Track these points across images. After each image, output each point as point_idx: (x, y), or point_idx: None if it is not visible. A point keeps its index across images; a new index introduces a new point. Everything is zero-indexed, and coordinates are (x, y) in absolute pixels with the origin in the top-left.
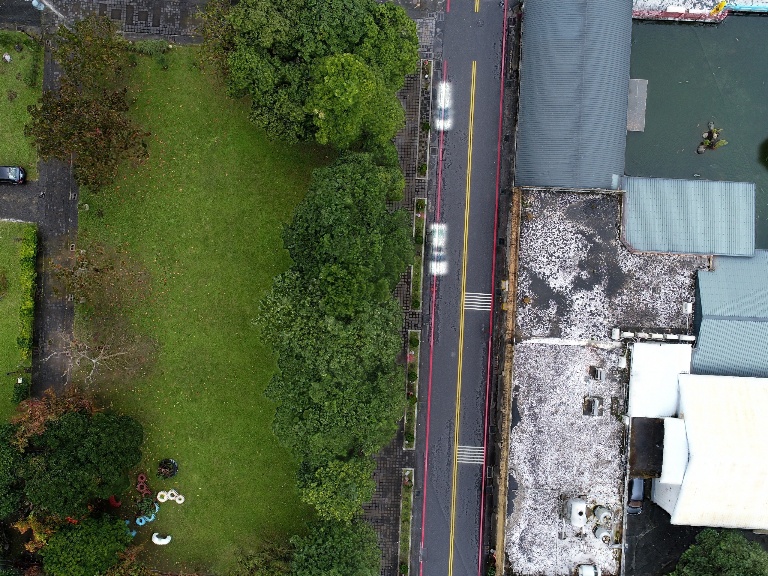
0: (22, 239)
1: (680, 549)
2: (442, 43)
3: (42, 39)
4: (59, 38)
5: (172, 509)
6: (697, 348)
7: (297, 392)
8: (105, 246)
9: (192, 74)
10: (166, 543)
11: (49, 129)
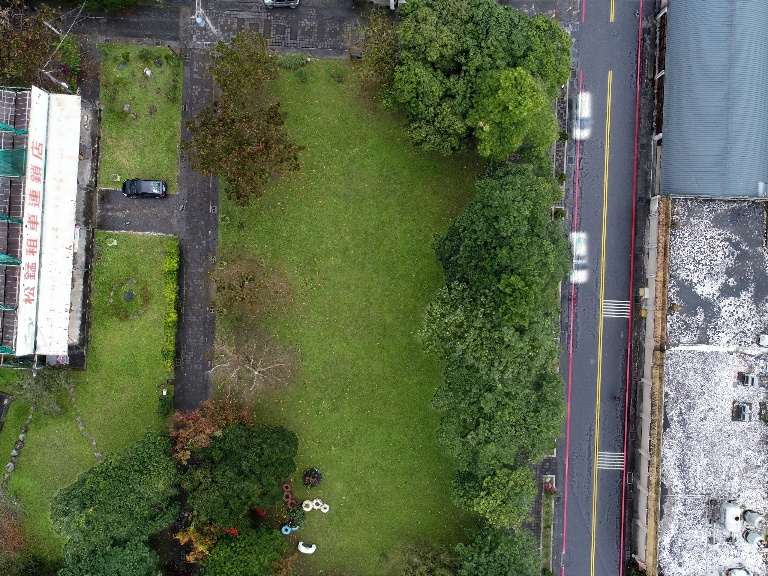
0: (167, 252)
1: None
2: (578, 53)
3: (181, 54)
4: (214, 54)
5: (316, 518)
6: None
7: (467, 402)
8: (246, 258)
9: (330, 87)
10: (312, 552)
11: (210, 144)
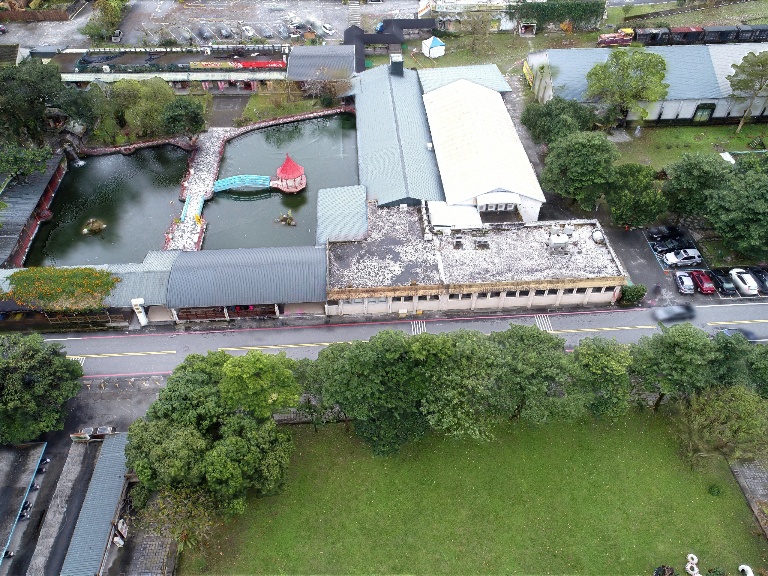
0: None
1: (562, 213)
2: None
3: None
4: None
5: None
6: None
7: None
8: None
9: None
10: (747, 567)
11: None
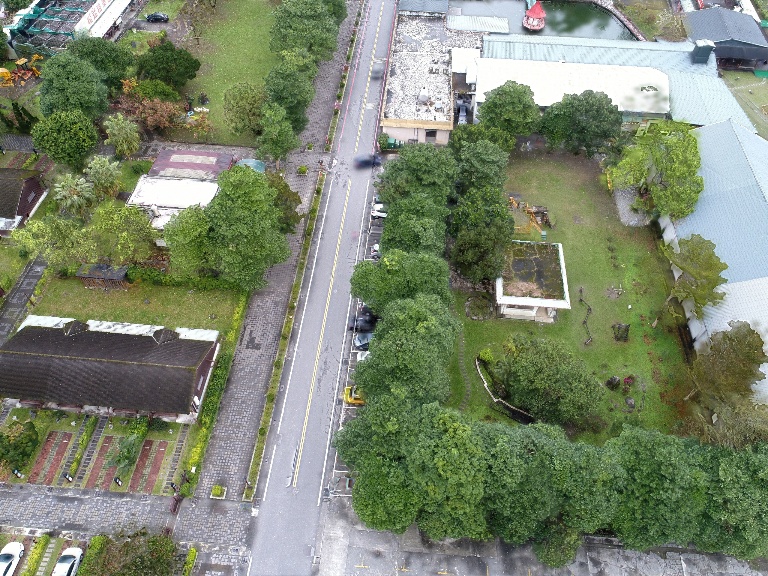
0: None
1: None
2: None
3: None
4: None
5: None
6: (484, 53)
7: None
8: None
9: None
10: None
11: None
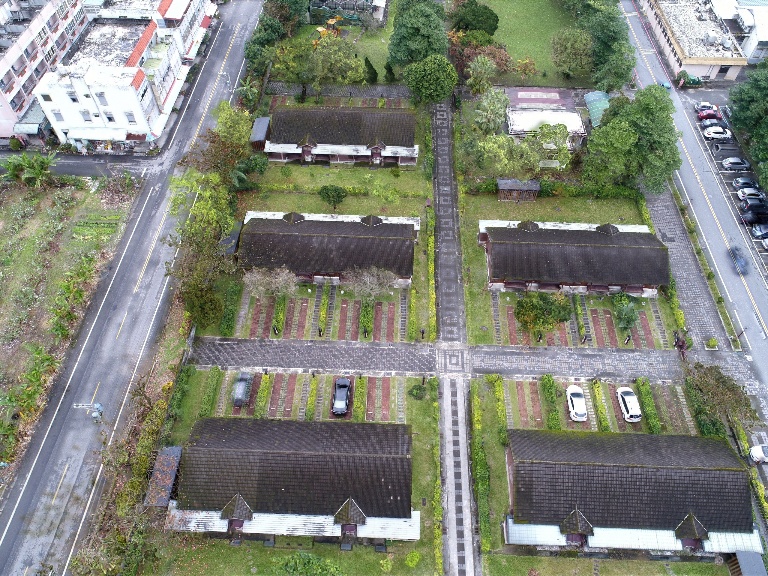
0: None
1: None
2: None
3: None
4: None
5: None
6: (738, 2)
7: None
8: None
9: None
10: None
11: None
